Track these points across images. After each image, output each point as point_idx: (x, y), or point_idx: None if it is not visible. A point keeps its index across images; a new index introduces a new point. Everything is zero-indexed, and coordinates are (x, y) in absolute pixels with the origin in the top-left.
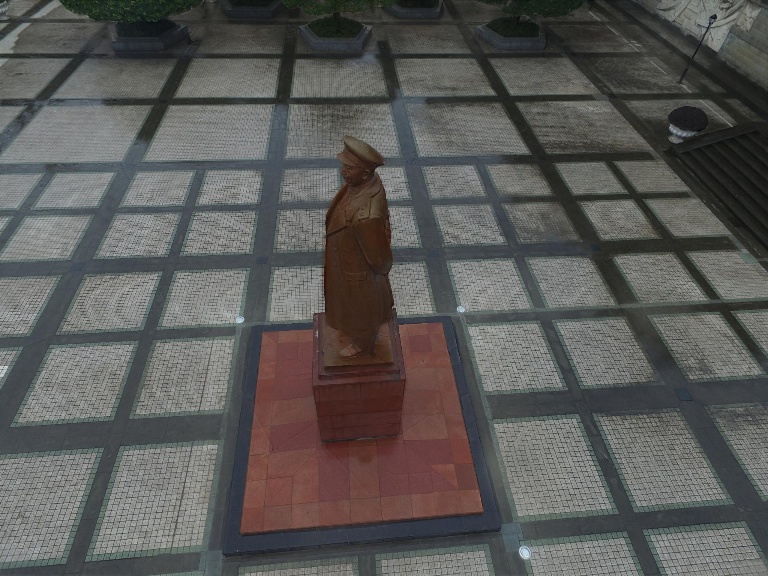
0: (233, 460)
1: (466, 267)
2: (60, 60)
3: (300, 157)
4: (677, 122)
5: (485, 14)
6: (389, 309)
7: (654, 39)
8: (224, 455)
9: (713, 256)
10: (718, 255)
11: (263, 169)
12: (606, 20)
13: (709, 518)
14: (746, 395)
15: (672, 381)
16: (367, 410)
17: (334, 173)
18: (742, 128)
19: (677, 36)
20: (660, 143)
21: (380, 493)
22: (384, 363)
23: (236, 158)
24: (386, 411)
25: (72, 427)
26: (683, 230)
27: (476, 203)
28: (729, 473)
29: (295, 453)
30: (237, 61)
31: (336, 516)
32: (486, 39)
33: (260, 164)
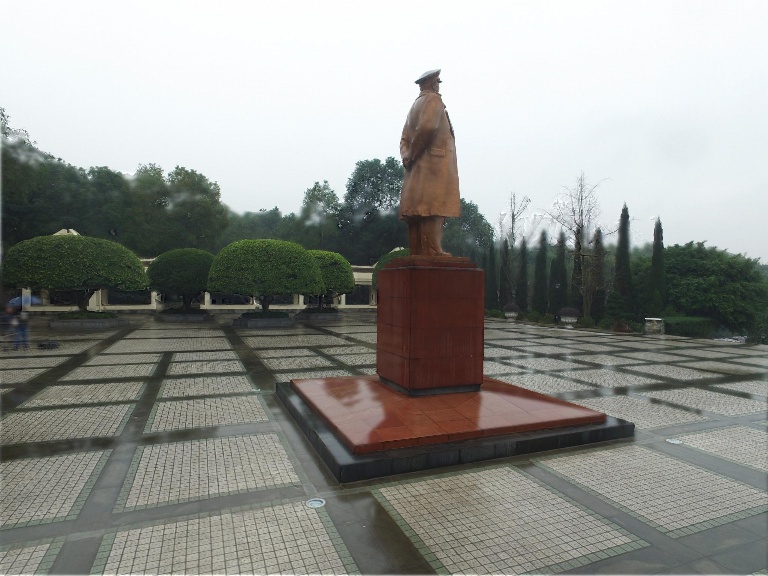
0: None
1: None
2: None
3: None
4: None
5: None
6: None
7: None
8: None
9: None
10: None
11: None
12: None
13: None
14: None
15: None
16: None
17: None
18: None
19: None
20: None
21: None
22: None
23: None
24: None
25: None
26: None
27: None
28: None
29: None
30: None
31: None
32: None
33: None
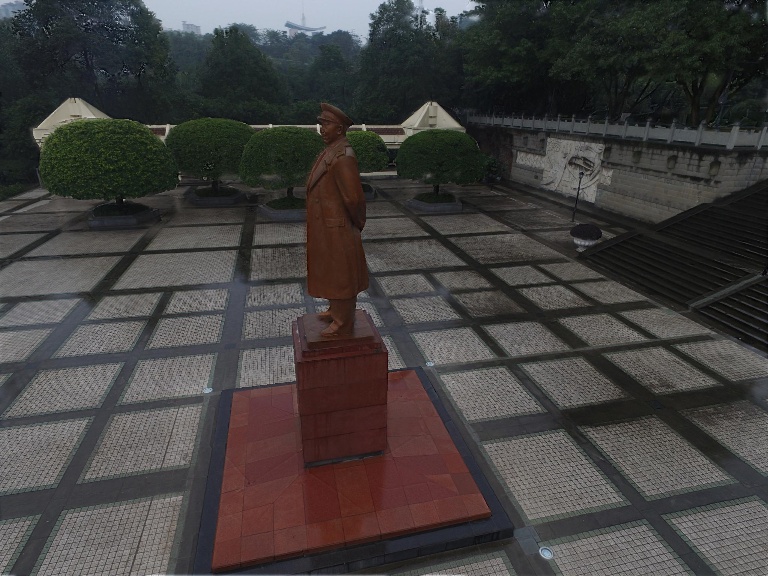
0: (201, 508)
1: (428, 336)
2: (36, 234)
3: (264, 278)
4: (578, 234)
5: (411, 195)
6: (366, 273)
7: (545, 202)
8: (190, 505)
9: (640, 313)
10: (644, 312)
11: (229, 288)
12: (505, 194)
13: (721, 497)
14: (710, 399)
15: (641, 396)
16: (352, 404)
17: (296, 286)
18: (628, 234)
19: (561, 199)
20: (570, 253)
21: (374, 508)
22: (365, 337)
23: (203, 282)
24: (371, 406)
25: (3, 499)
26: (609, 299)
27: (428, 296)
28: (723, 458)
29: (275, 482)
30: (203, 228)
31: (327, 536)
32: (415, 207)
33: (226, 285)
